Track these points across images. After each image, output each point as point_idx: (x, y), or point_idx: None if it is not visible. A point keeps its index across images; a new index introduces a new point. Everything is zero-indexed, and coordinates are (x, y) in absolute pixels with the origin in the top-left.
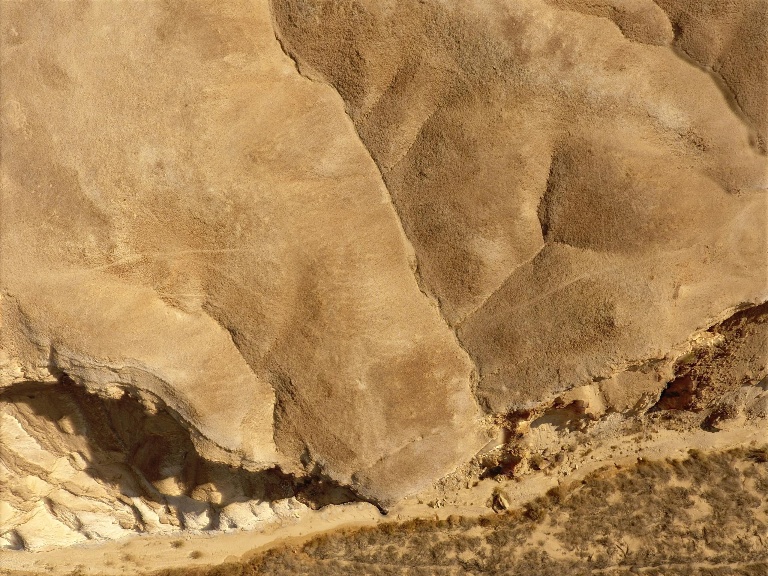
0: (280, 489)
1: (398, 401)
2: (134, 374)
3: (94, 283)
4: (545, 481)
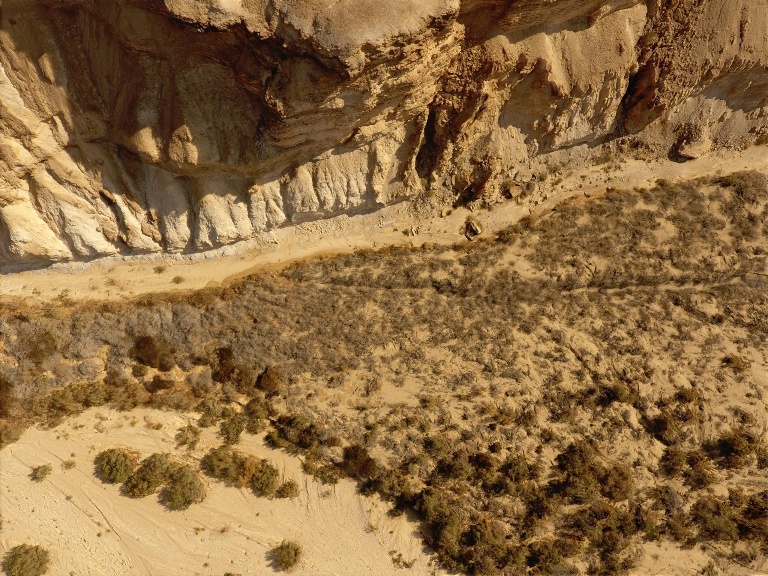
0: (254, 146)
1: None
2: None
3: None
4: (517, 210)
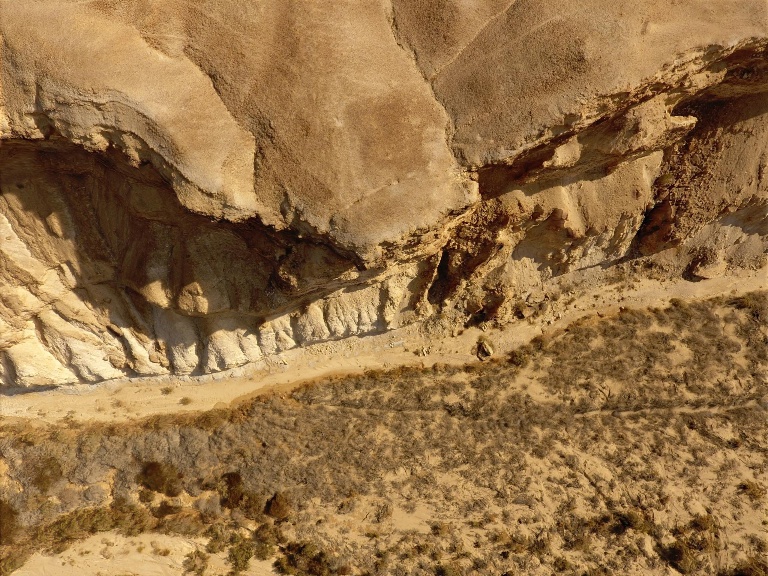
0: (265, 297)
1: (374, 141)
2: (117, 111)
3: (78, 17)
4: (529, 330)
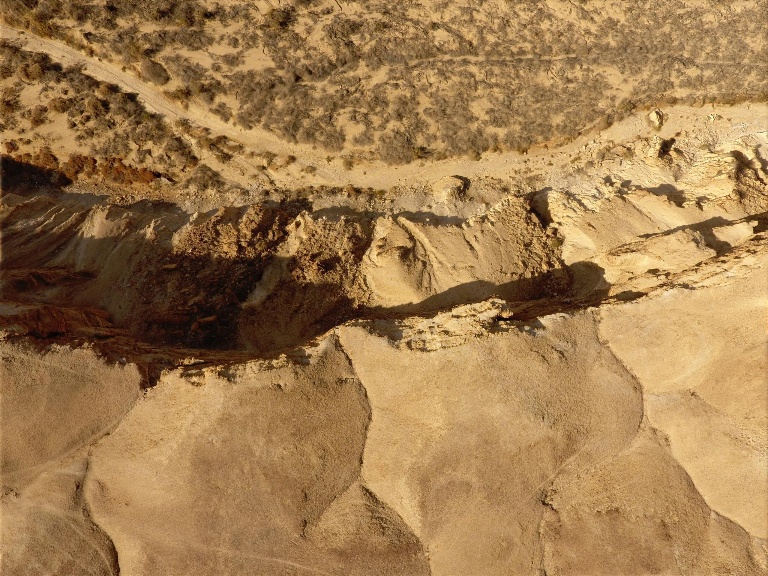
0: None
1: None
2: None
3: None
4: (613, 136)
